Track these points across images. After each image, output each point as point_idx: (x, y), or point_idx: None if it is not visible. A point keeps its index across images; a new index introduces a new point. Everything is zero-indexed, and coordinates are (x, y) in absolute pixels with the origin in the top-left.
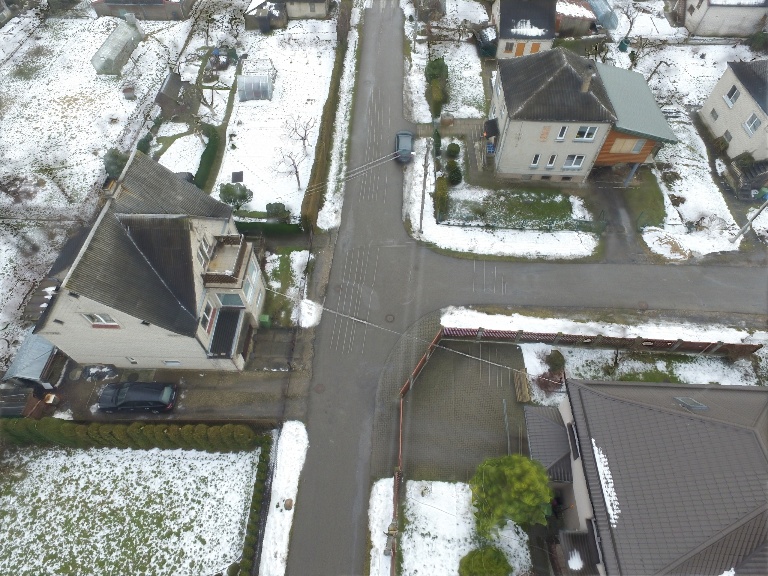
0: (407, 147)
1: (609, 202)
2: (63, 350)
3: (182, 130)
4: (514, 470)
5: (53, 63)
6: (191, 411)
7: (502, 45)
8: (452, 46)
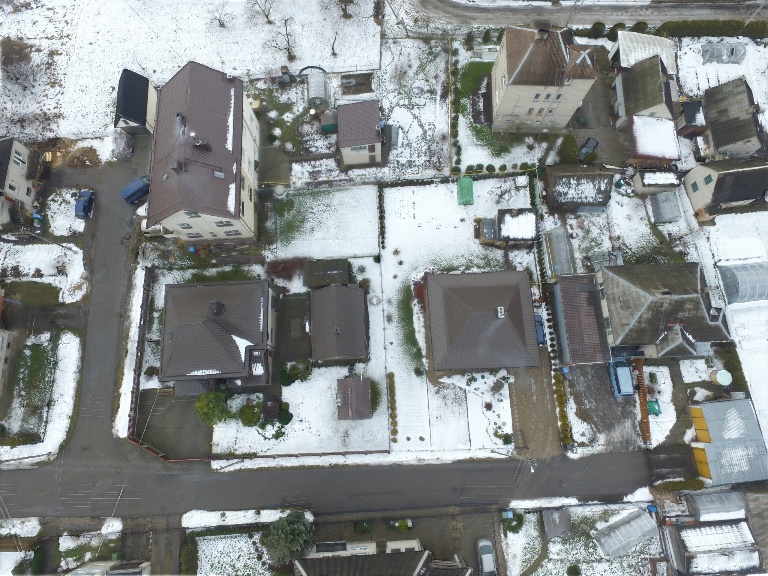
0: None
1: (35, 318)
2: None
3: None
4: None
5: None
6: None
7: None
8: None
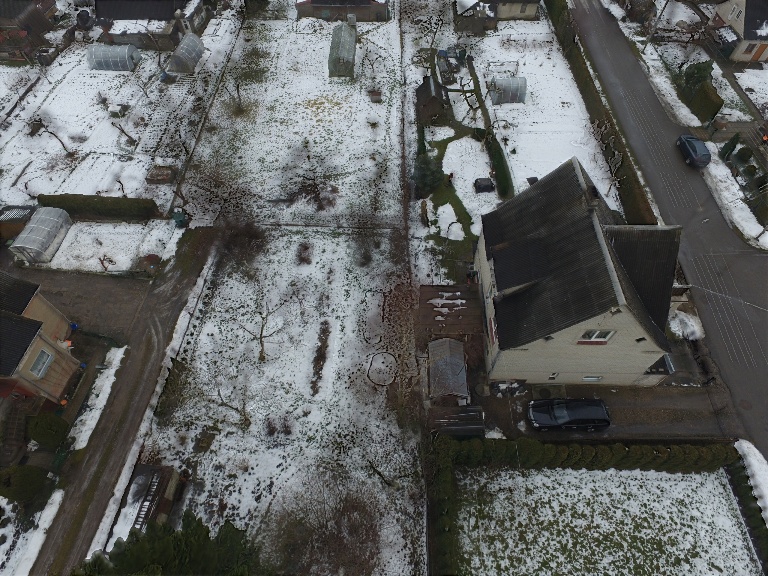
0: (707, 152)
1: None
2: (498, 366)
3: (449, 134)
4: None
5: (276, 65)
6: (623, 429)
7: (743, 46)
8: (679, 47)
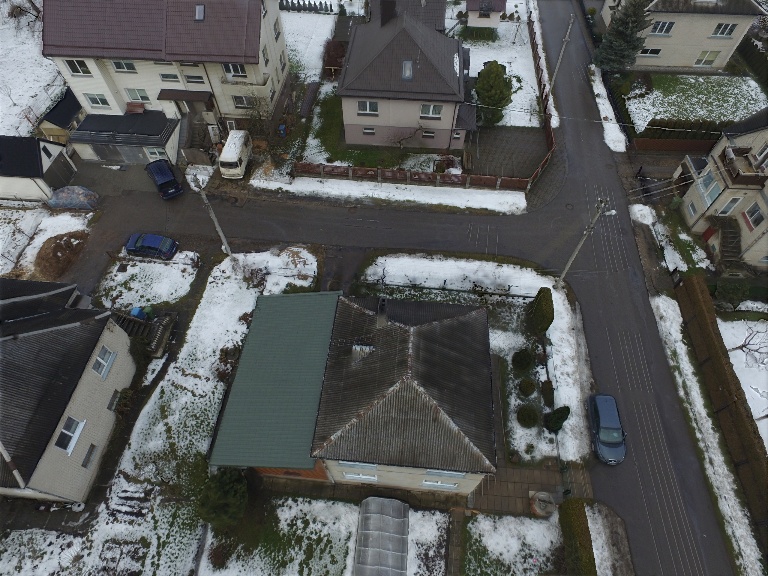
0: (603, 400)
1: None
2: None
3: None
4: None
5: None
6: None
7: None
8: None
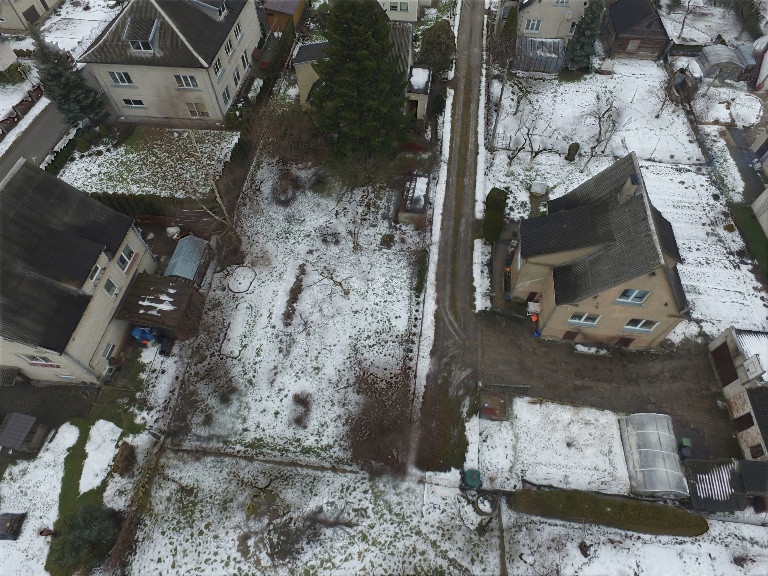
0: None
1: None
2: None
3: None
4: None
5: None
6: None
7: None
8: None
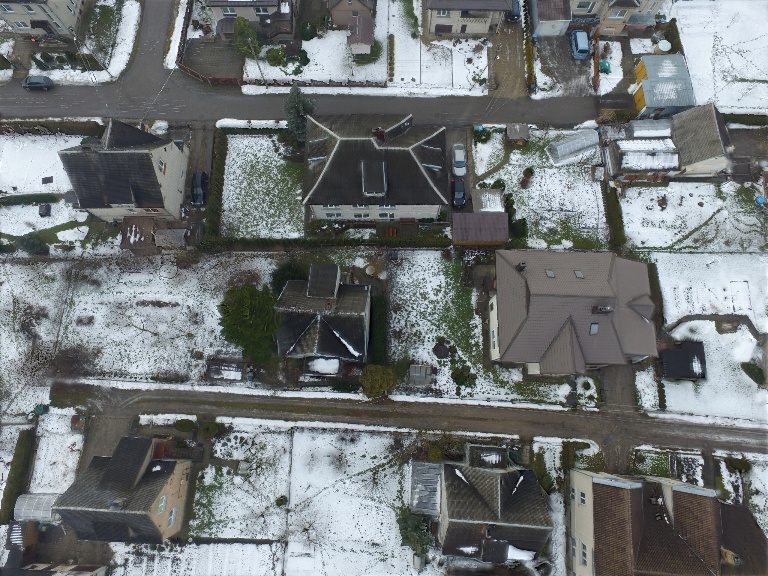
0: (41, 77)
1: None
2: None
3: None
4: (237, 25)
5: None
6: (208, 168)
7: None
8: None
